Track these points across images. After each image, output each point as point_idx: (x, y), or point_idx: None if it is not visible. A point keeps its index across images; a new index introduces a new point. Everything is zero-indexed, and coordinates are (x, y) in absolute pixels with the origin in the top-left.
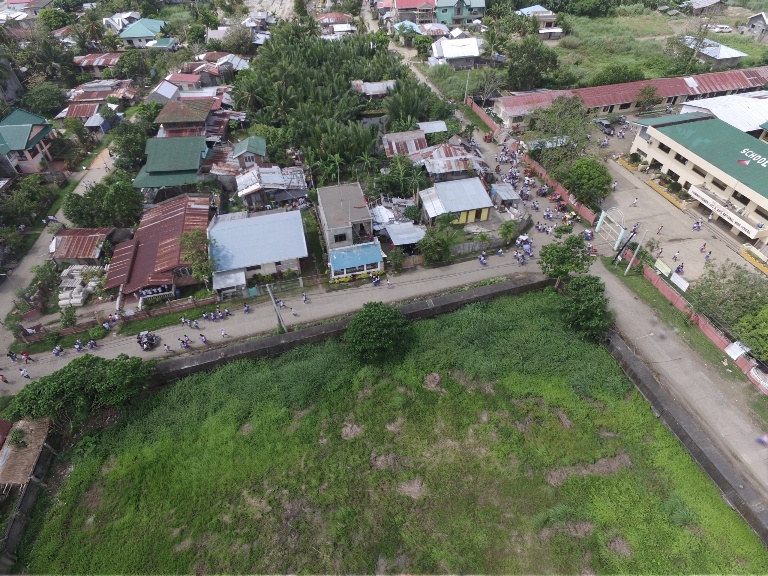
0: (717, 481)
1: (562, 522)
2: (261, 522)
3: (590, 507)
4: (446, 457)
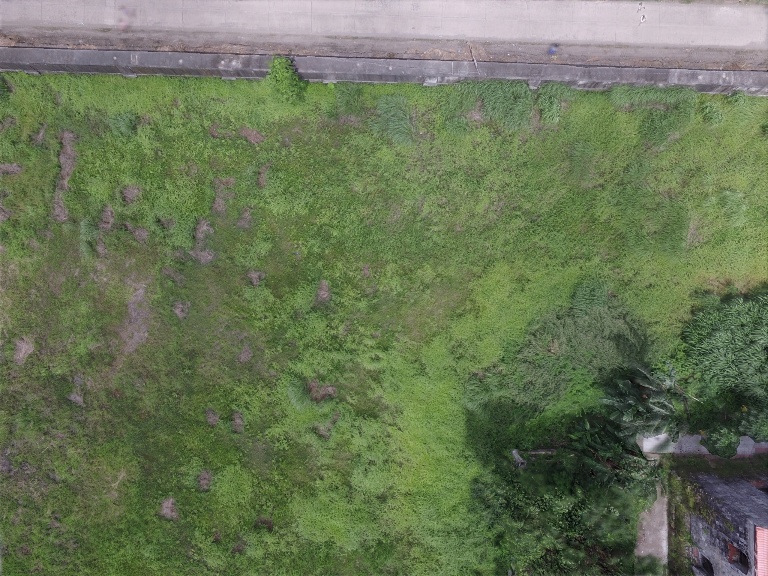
0: (110, 71)
1: (93, 233)
2: (4, 495)
3: (92, 199)
4: (5, 306)
